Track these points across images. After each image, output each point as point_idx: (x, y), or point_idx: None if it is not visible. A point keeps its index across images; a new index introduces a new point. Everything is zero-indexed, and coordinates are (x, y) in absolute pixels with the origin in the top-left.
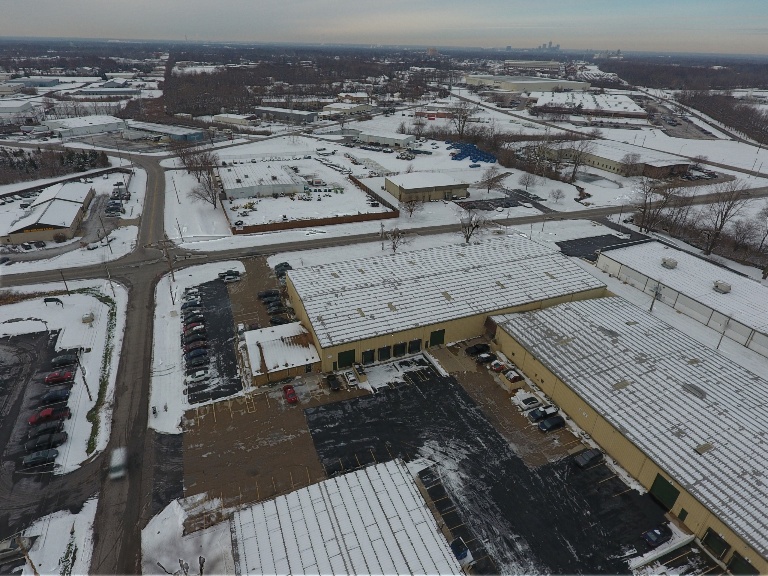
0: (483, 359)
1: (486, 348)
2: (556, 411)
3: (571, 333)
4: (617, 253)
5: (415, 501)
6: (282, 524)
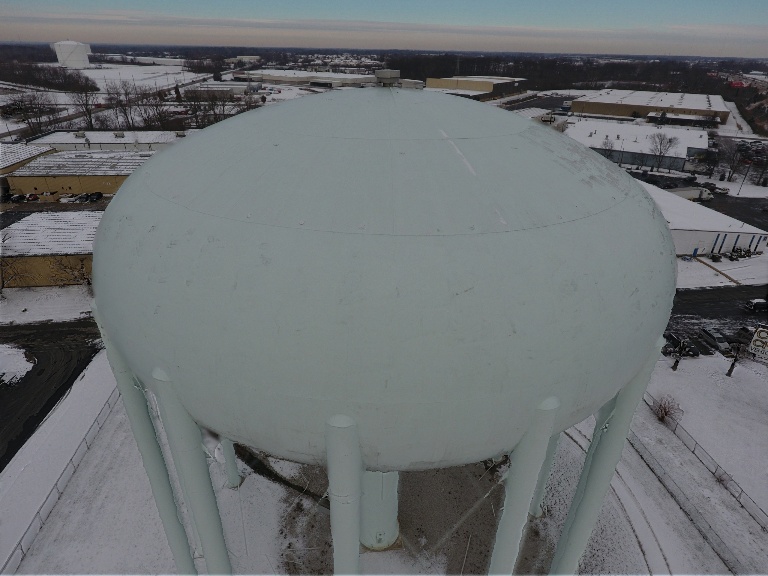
0: (17, 197)
1: (11, 195)
2: (92, 193)
3: (62, 163)
4: (39, 141)
5: (67, 213)
6: (4, 242)
